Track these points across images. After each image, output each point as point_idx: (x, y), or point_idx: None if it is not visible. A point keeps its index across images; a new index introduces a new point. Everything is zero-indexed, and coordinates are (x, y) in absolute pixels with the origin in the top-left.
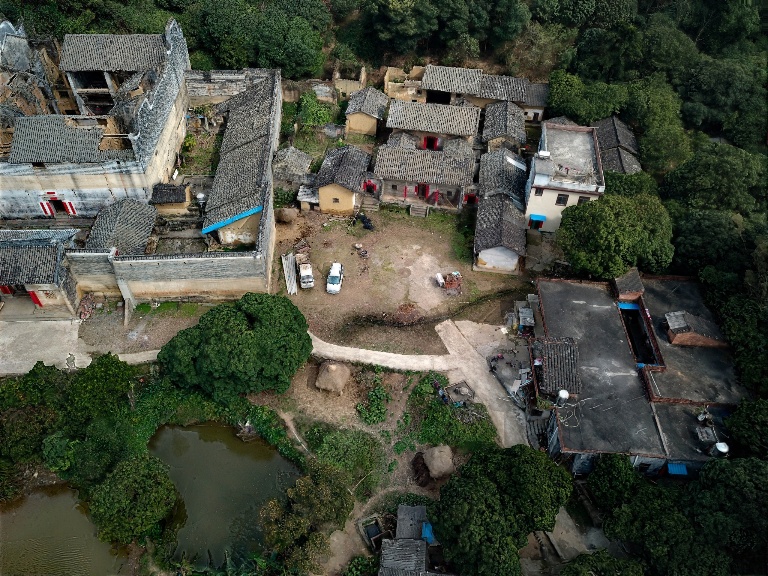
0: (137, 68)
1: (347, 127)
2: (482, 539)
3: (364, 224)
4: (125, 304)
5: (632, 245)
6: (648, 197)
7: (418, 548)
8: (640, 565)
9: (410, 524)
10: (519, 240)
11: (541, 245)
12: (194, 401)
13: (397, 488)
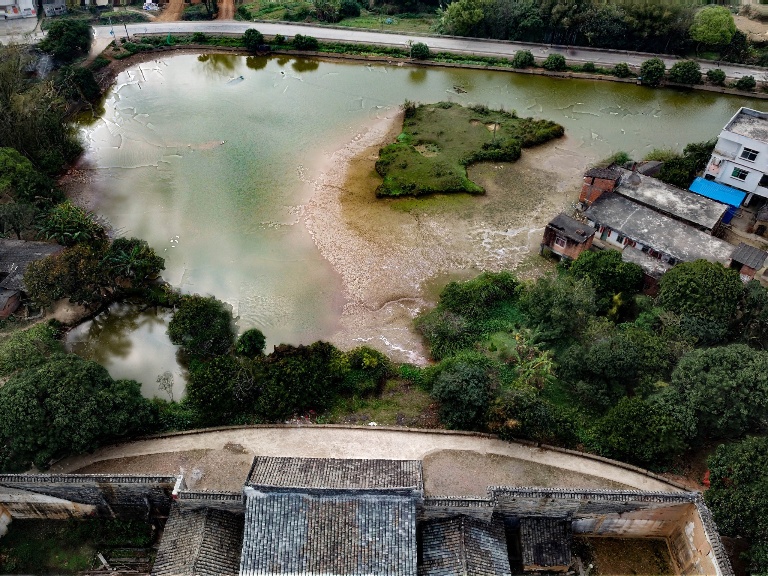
0: None
1: None
2: None
3: None
4: None
5: None
6: None
7: (7, 282)
8: None
9: (3, 295)
10: None
11: None
12: None
13: None
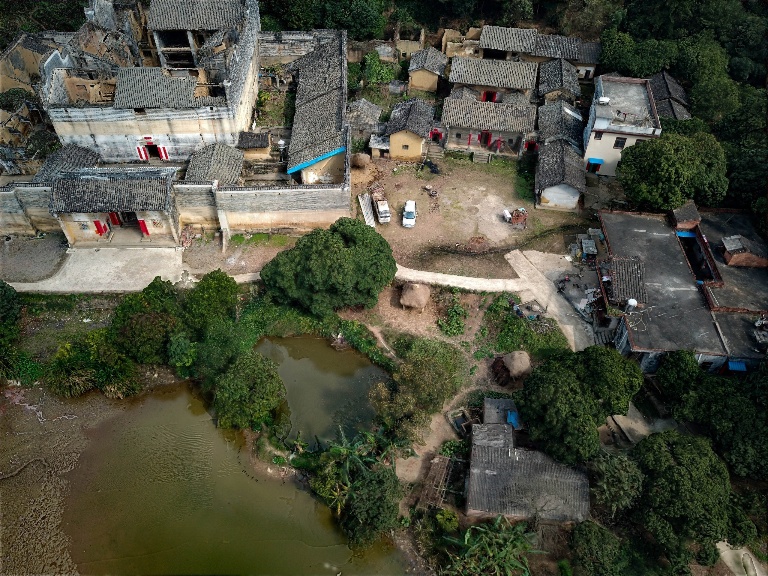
0: (218, 27)
1: (410, 84)
2: (567, 415)
3: (431, 169)
4: (223, 233)
5: (690, 178)
6: (705, 135)
7: (505, 430)
8: (707, 440)
9: (496, 412)
10: (580, 180)
11: (598, 187)
12: (290, 316)
13: (480, 387)
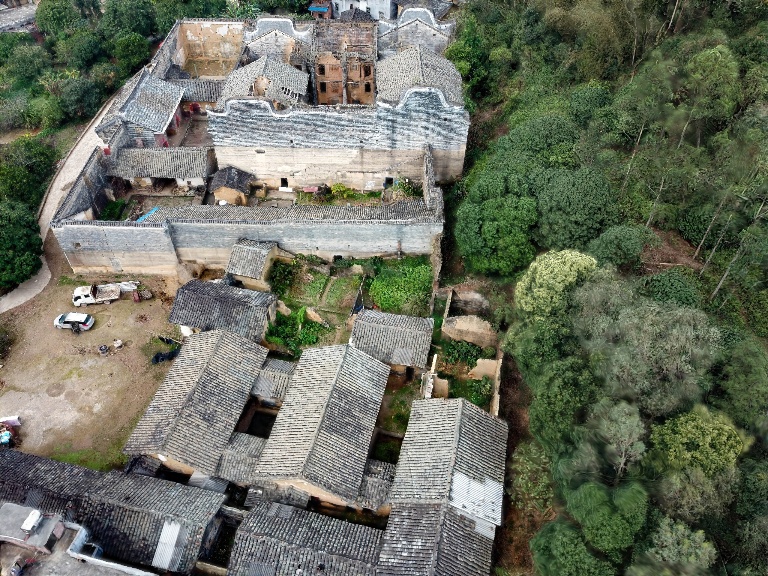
0: None
1: None
2: None
3: None
4: None
5: None
6: None
7: None
8: None
9: None
10: None
11: None
12: None
13: None
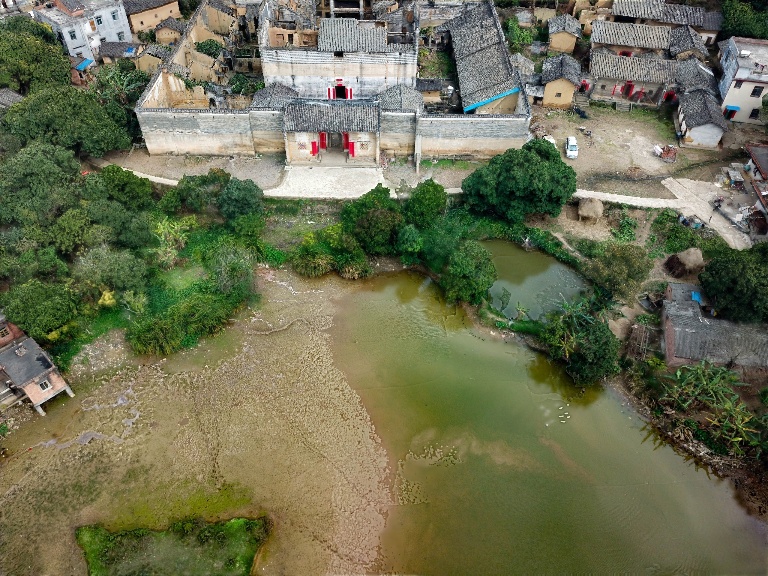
0: None
1: (550, 45)
2: (756, 285)
3: (580, 115)
4: (417, 157)
5: None
6: None
7: (693, 305)
8: None
9: (682, 292)
10: (722, 122)
11: (734, 131)
12: (483, 223)
13: (658, 279)
